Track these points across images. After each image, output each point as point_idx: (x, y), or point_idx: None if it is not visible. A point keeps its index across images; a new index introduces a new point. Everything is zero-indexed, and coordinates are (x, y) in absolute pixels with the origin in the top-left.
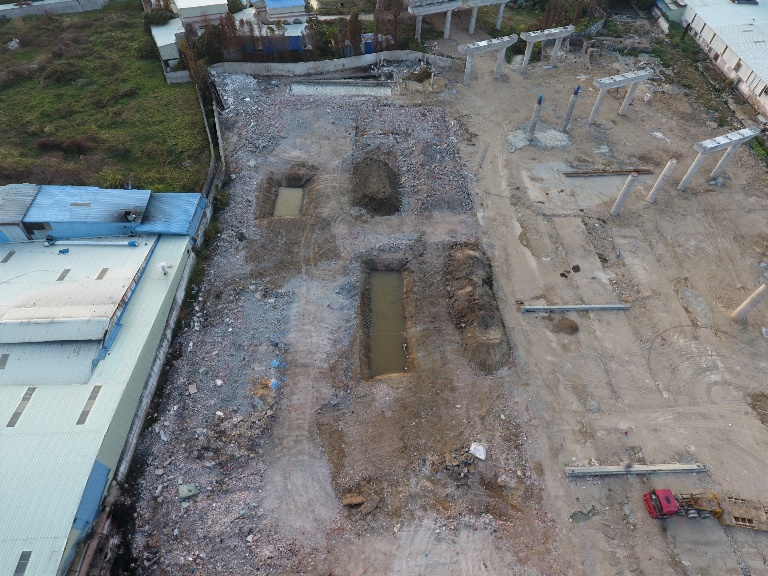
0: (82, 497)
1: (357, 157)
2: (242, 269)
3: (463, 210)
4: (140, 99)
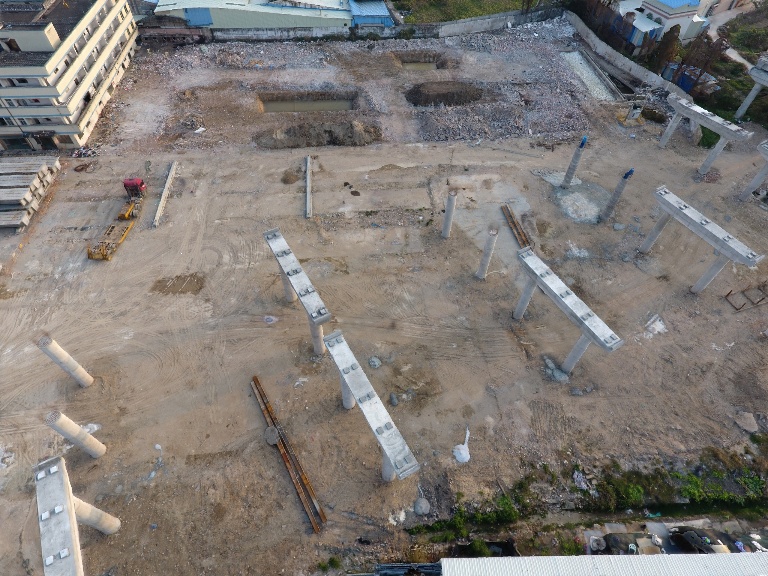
0: None
1: (481, 86)
2: (343, 50)
3: (423, 135)
4: (509, 0)
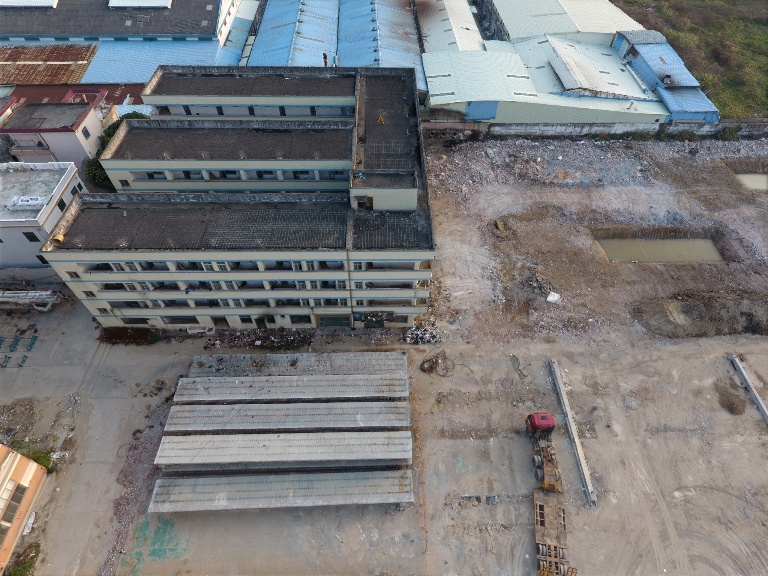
0: (479, 103)
1: None
2: (660, 156)
3: None
4: None
